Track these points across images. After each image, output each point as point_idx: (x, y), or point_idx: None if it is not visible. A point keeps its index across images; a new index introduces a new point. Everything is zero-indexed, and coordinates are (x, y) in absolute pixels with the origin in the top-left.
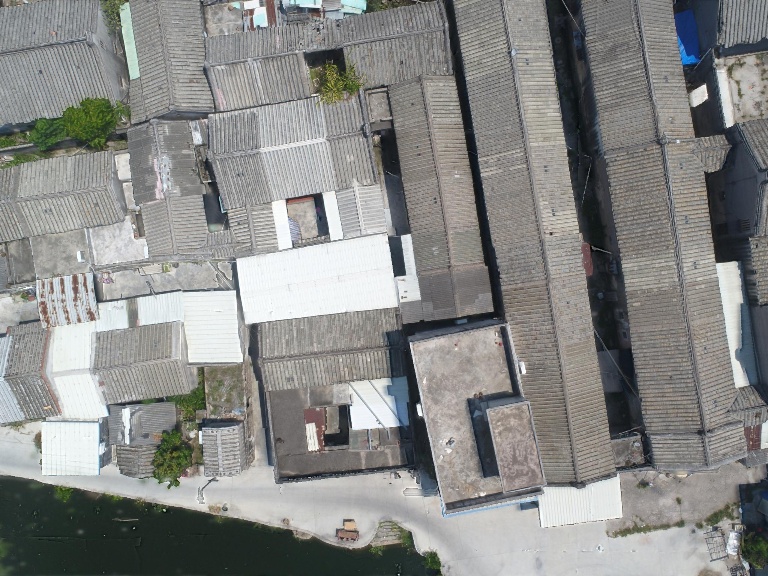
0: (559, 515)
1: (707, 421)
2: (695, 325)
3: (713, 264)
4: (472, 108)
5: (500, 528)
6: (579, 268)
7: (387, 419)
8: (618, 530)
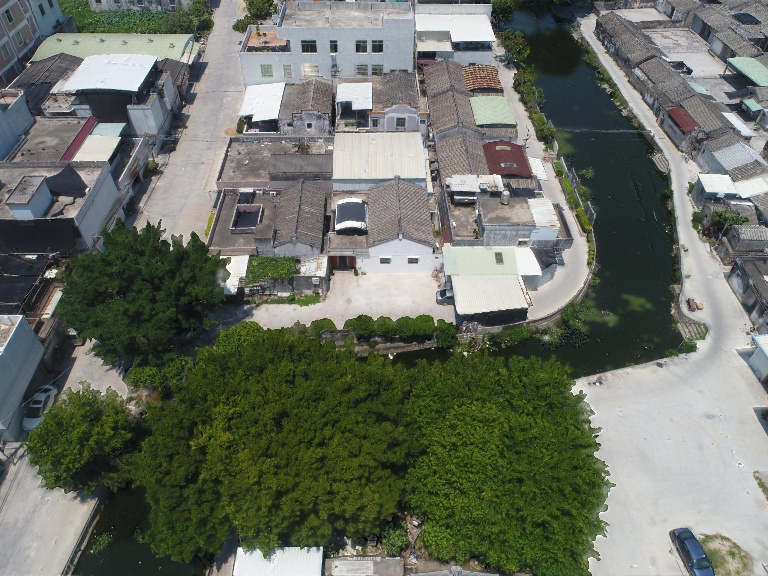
0: None
1: None
2: None
3: None
4: None
5: (732, 392)
6: None
7: None
8: (763, 481)
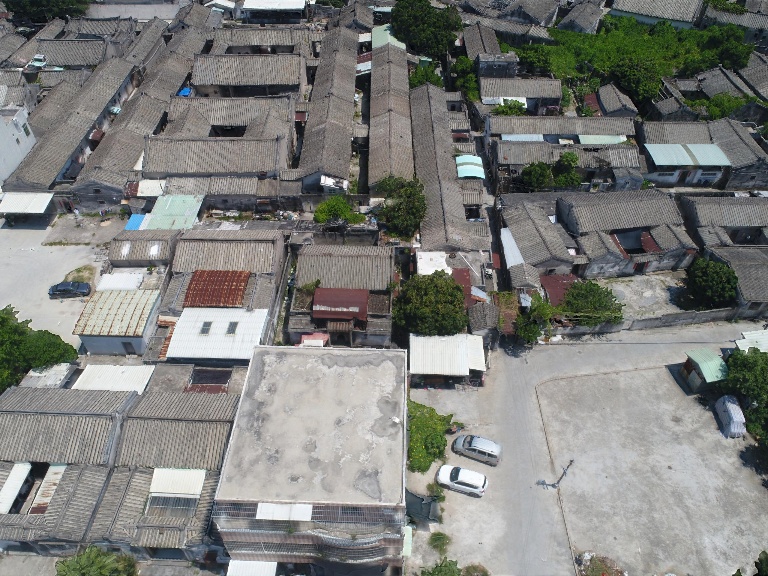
0: (9, 208)
1: (103, 166)
2: (121, 140)
3: (150, 133)
4: None
5: None
6: (86, 127)
7: None
8: None
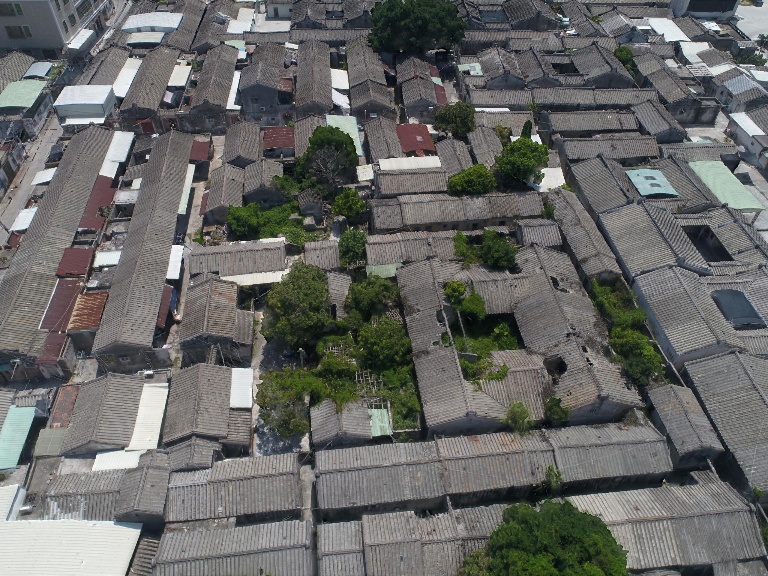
0: None
1: None
2: None
3: None
4: (598, 2)
5: None
6: None
7: (714, 24)
8: None
